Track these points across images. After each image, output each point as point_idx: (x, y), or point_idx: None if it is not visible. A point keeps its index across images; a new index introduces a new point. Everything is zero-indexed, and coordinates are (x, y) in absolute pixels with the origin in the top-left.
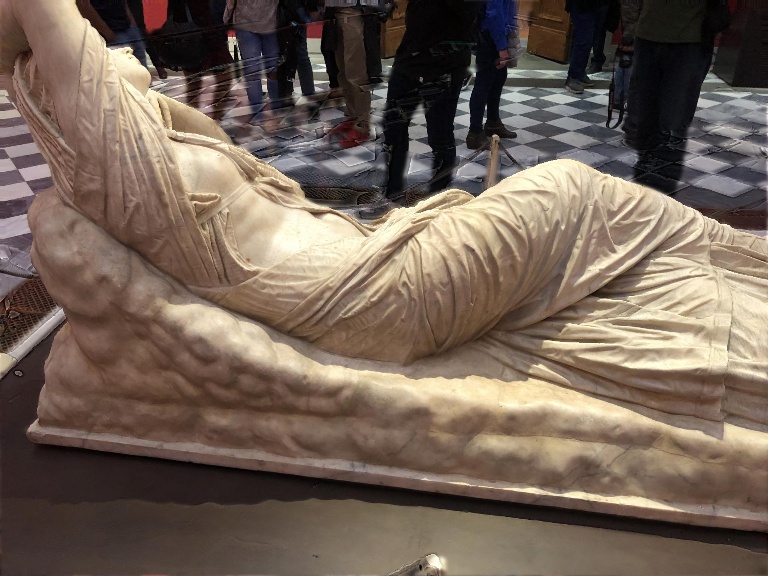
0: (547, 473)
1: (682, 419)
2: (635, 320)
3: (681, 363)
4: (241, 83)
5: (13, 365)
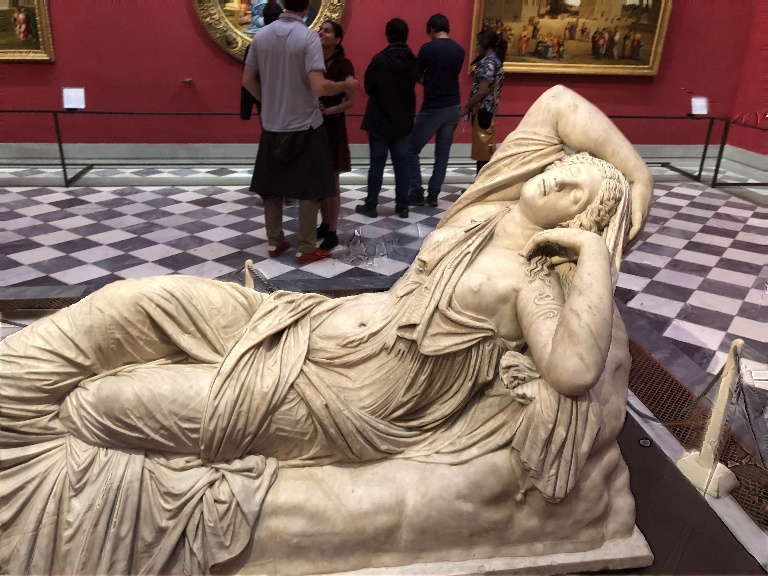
0: None
1: None
2: None
3: None
4: None
5: (708, 491)
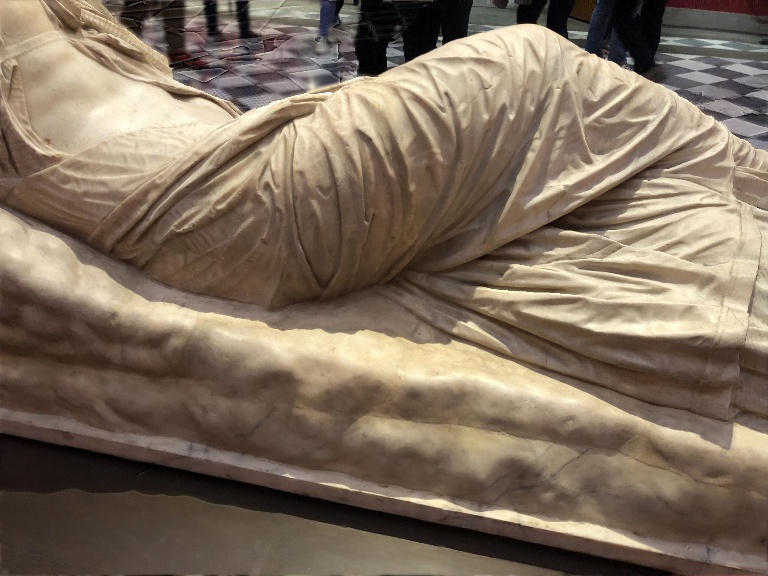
0: (461, 480)
1: (670, 414)
2: (611, 262)
3: (673, 327)
4: None
5: None
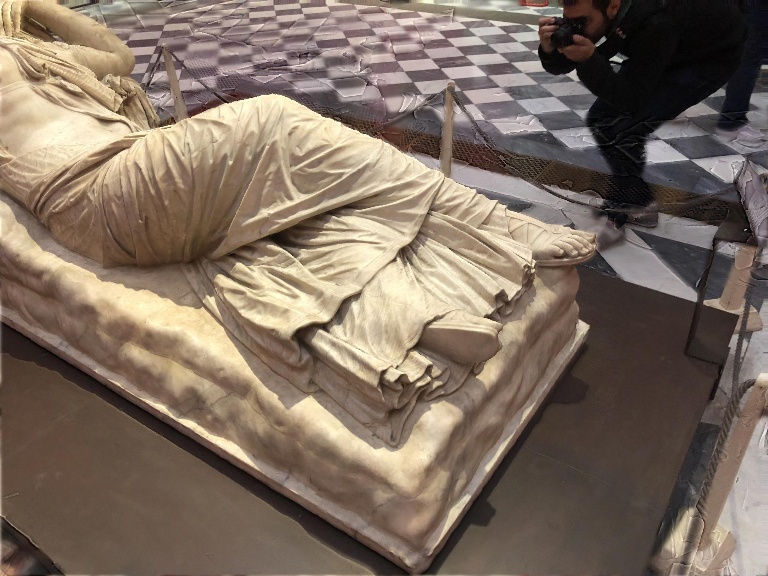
0: (169, 395)
1: (278, 380)
2: (280, 272)
3: (271, 321)
4: (248, 3)
5: None
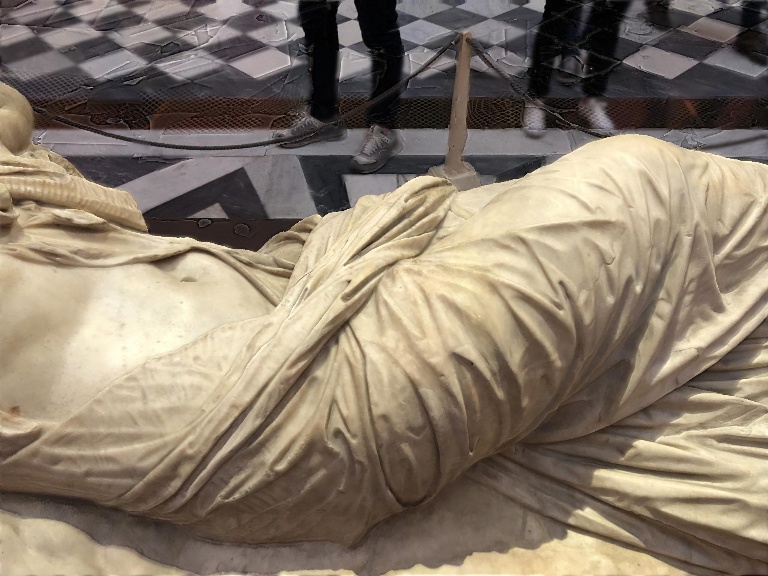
0: None
1: None
2: (762, 438)
3: None
4: None
5: None
